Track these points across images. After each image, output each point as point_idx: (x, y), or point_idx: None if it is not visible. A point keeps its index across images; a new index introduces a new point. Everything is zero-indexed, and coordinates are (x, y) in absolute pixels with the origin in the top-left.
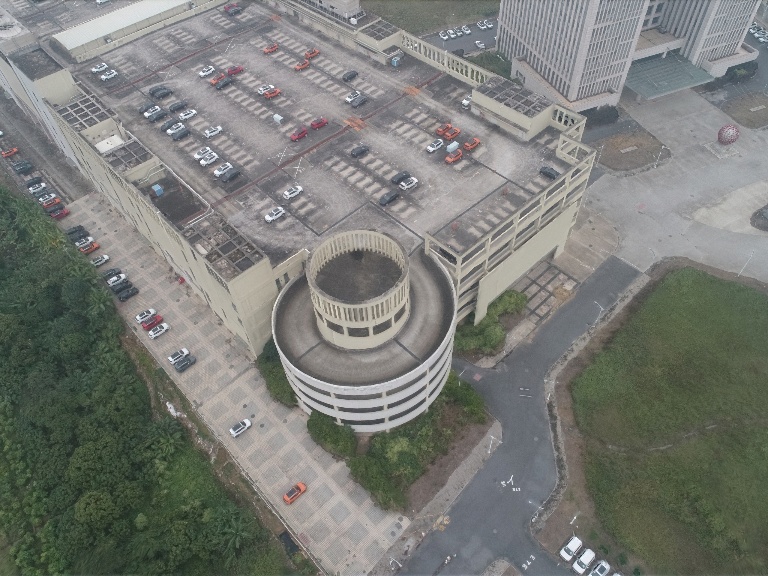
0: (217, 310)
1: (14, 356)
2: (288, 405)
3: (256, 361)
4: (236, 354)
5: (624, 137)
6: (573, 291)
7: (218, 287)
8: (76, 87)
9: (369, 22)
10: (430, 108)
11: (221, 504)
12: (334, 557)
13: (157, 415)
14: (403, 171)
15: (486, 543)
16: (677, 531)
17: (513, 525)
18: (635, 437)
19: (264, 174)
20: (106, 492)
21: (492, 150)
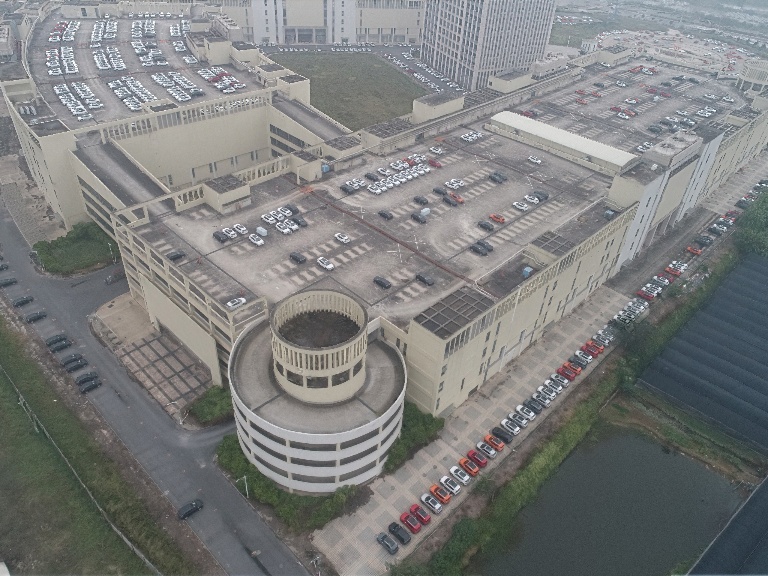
0: None
1: None
2: None
3: (767, 147)
4: None
5: None
6: None
7: None
8: None
9: None
10: (615, 73)
11: None
12: None
13: None
14: (672, 79)
15: None
16: None
17: None
18: None
19: None
20: None
21: None
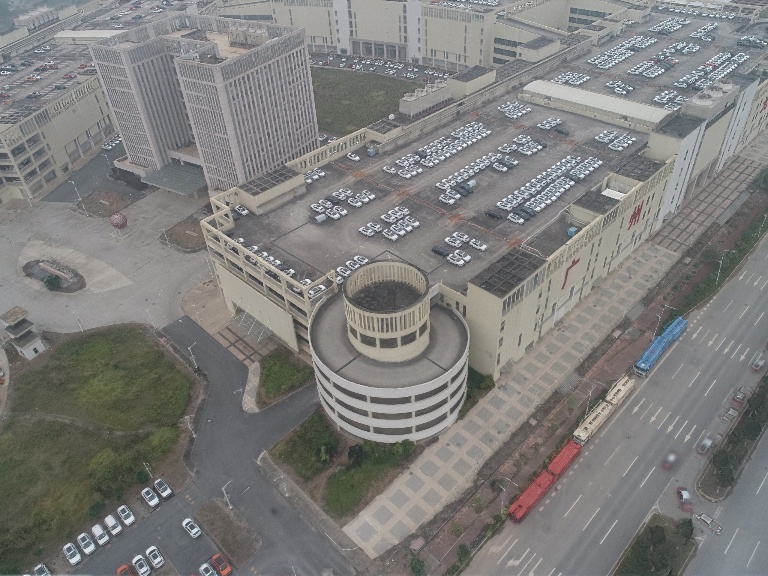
0: None
1: None
2: None
3: None
4: None
5: (120, 197)
6: None
7: None
8: None
9: None
10: None
11: None
12: None
13: None
14: None
15: None
16: None
17: None
18: None
19: None
20: None
21: None
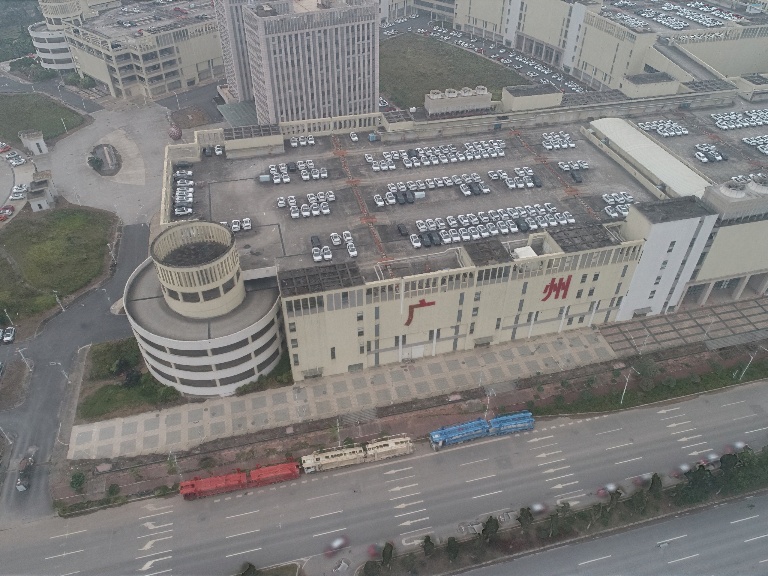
0: None
1: None
2: None
3: None
4: None
5: (204, 117)
6: None
7: None
8: None
9: None
10: None
11: None
12: None
13: None
14: None
15: None
16: None
17: None
18: None
19: None
20: None
21: None
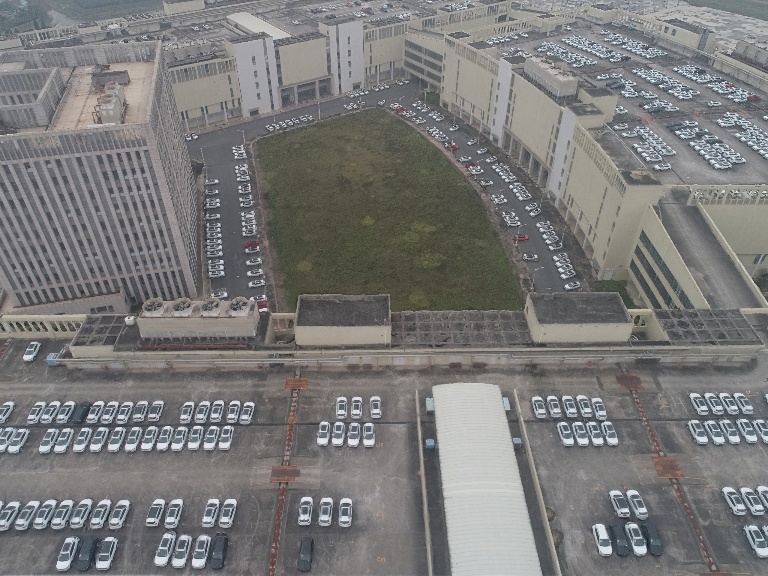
0: None
1: None
2: None
3: None
4: None
5: None
6: None
7: None
8: None
9: None
10: None
11: None
12: None
13: None
14: None
15: None
16: None
17: None
18: None
19: None
20: None
21: None
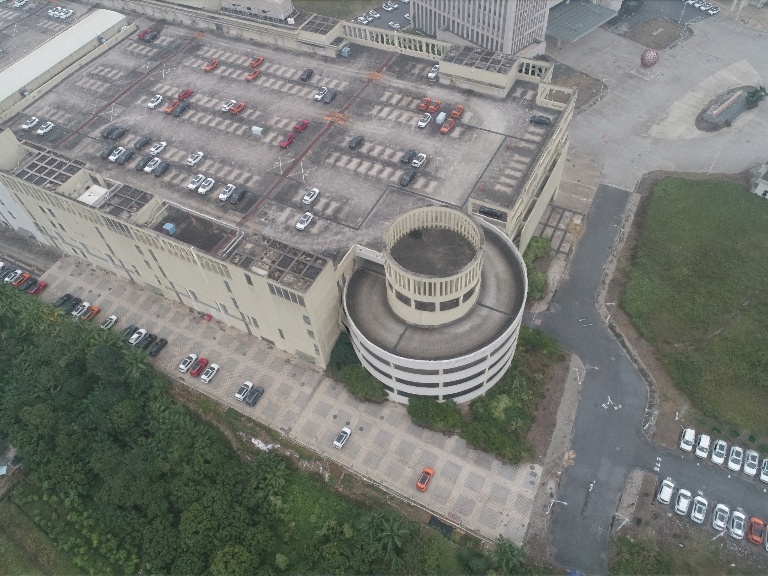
0: (268, 333)
1: (64, 446)
2: (378, 402)
3: (327, 371)
4: (301, 371)
5: (562, 80)
6: (583, 224)
7: (283, 305)
8: (22, 147)
9: (306, 19)
10: (400, 88)
11: (354, 516)
12: (490, 523)
13: (245, 456)
14: (407, 150)
15: (615, 461)
16: (761, 396)
17: (630, 438)
18: (693, 330)
19: (271, 186)
20: (236, 545)
21: (477, 113)
